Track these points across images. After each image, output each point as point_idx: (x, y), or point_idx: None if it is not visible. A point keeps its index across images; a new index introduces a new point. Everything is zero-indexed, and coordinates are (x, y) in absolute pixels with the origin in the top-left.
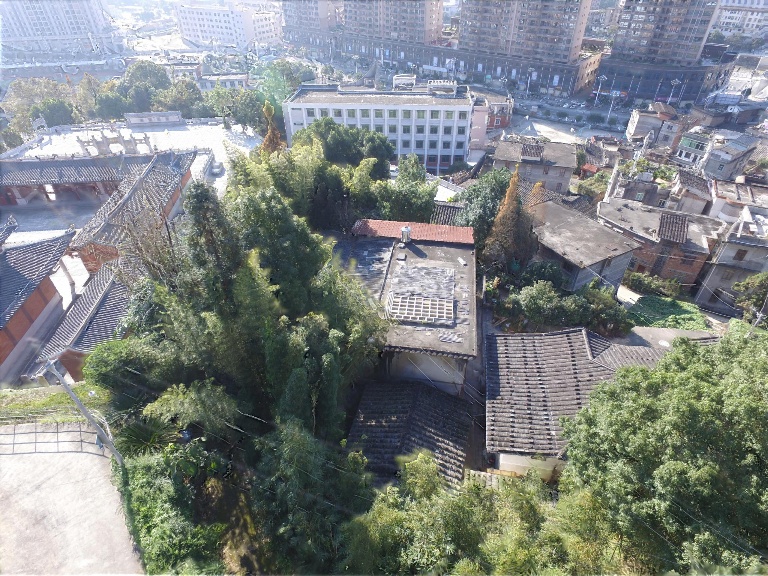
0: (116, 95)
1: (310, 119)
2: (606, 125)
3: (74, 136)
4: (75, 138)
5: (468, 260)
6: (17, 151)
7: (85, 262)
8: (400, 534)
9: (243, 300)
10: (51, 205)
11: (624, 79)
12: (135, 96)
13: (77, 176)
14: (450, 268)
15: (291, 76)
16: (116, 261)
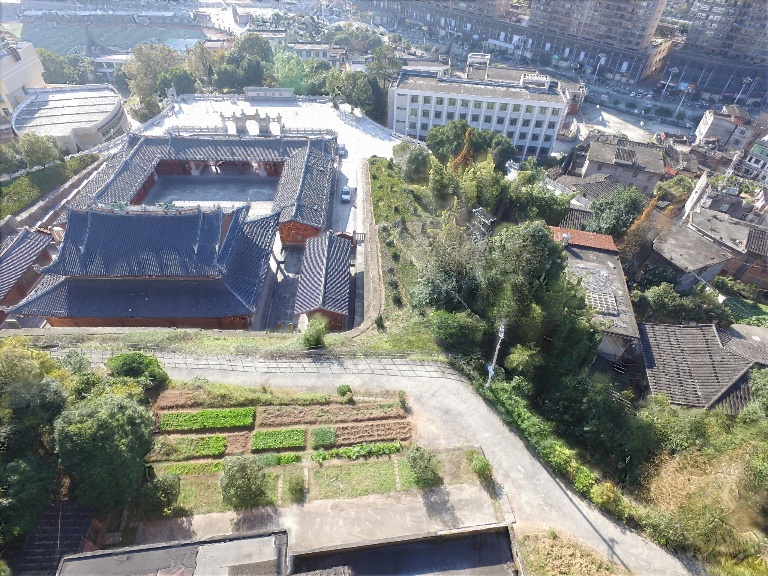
0: (232, 67)
1: (413, 105)
2: (673, 119)
3: (201, 106)
4: (202, 108)
5: (615, 264)
6: (157, 118)
7: (281, 235)
8: (660, 435)
9: (560, 299)
10: (219, 177)
11: (694, 72)
12: (247, 69)
13: (246, 155)
14: (604, 270)
15: (393, 60)
16: (319, 238)
